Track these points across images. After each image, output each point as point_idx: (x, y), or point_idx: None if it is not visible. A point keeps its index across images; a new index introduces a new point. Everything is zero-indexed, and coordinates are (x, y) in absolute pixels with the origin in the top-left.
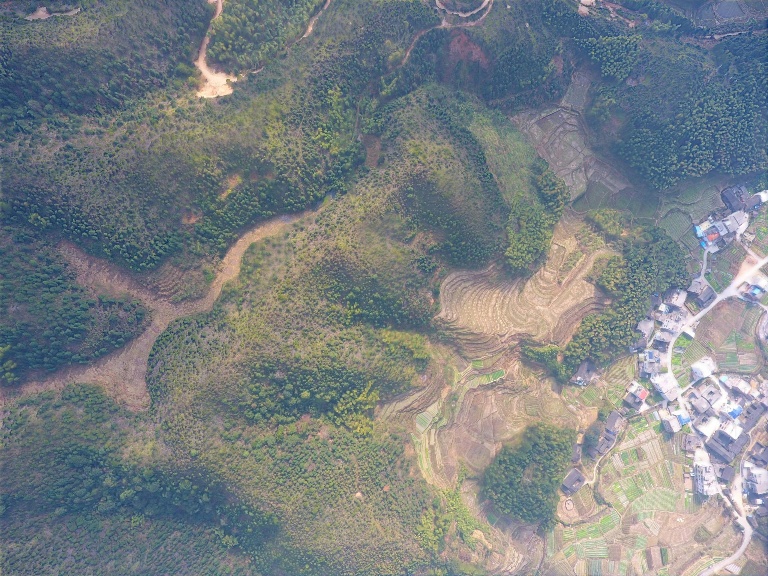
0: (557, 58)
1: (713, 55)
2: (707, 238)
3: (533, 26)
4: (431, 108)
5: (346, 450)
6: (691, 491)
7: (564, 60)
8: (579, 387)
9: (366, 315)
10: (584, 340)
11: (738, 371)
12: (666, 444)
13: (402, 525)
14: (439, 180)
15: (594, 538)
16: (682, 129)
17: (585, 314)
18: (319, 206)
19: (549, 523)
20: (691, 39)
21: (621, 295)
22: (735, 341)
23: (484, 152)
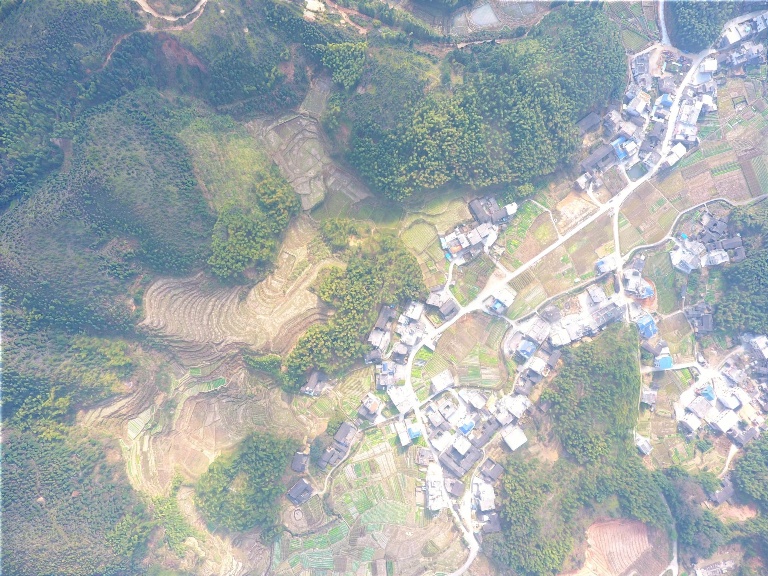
0: (287, 64)
1: (440, 64)
2: (450, 250)
3: (253, 31)
4: (132, 113)
5: (23, 455)
6: (422, 505)
7: (295, 66)
8: (311, 397)
9: (52, 321)
10: (301, 351)
11: (479, 386)
12: (399, 457)
13: (91, 531)
14: (115, 187)
15: (321, 549)
16: (403, 139)
17: (309, 324)
18: (5, 210)
19: (270, 532)
20: (430, 47)
21: (340, 306)
22: (478, 355)
23: (190, 159)
